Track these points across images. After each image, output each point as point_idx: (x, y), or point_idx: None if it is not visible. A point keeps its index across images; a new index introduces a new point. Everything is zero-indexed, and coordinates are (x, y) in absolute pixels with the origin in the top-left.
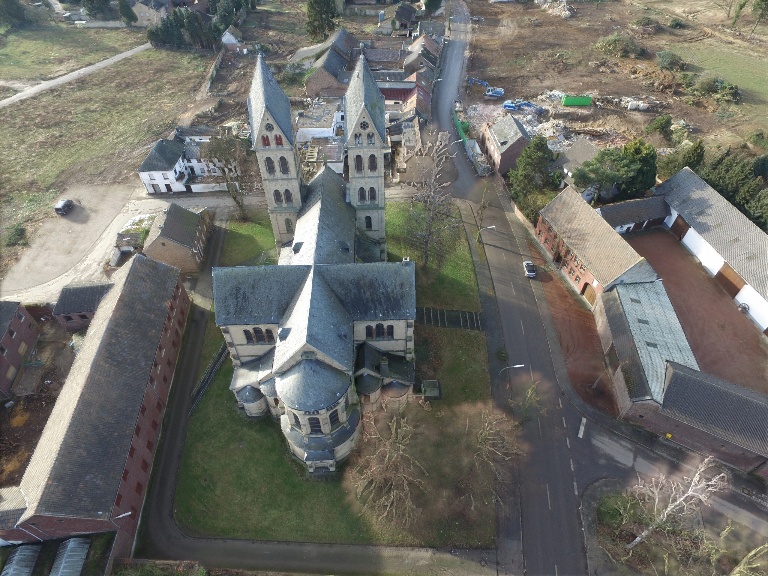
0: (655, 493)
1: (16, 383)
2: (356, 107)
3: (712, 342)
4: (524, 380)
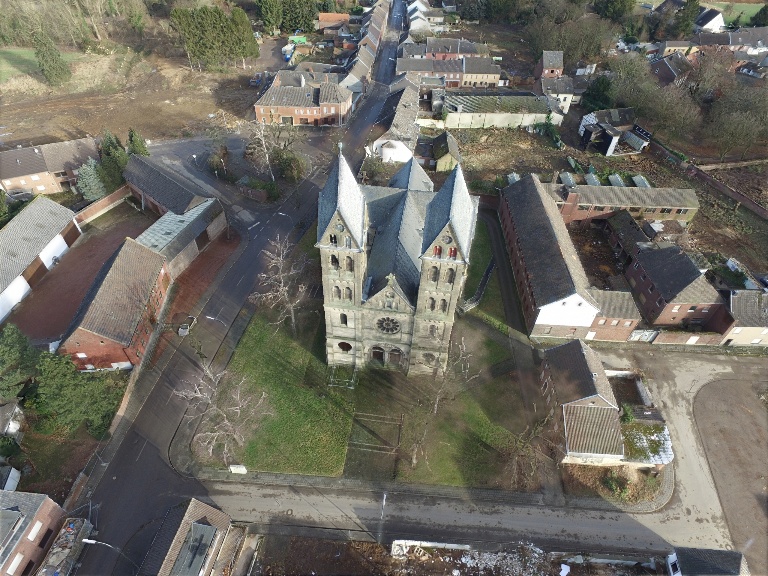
0: (264, 160)
1: None
2: None
3: (114, 249)
4: (268, 249)
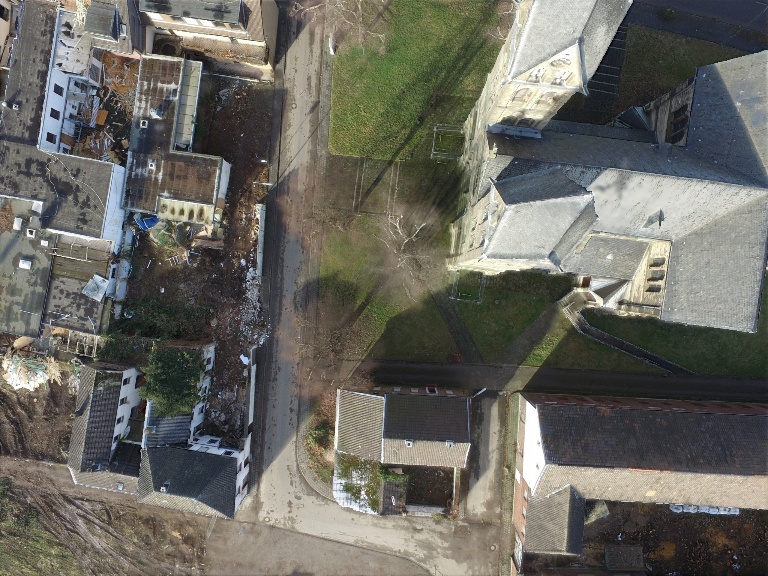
0: None
1: (634, 568)
2: (610, 23)
3: None
4: None
